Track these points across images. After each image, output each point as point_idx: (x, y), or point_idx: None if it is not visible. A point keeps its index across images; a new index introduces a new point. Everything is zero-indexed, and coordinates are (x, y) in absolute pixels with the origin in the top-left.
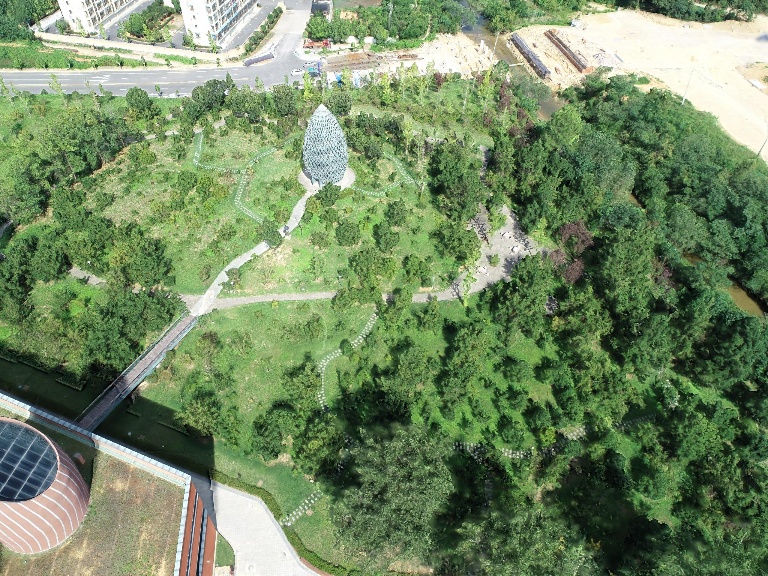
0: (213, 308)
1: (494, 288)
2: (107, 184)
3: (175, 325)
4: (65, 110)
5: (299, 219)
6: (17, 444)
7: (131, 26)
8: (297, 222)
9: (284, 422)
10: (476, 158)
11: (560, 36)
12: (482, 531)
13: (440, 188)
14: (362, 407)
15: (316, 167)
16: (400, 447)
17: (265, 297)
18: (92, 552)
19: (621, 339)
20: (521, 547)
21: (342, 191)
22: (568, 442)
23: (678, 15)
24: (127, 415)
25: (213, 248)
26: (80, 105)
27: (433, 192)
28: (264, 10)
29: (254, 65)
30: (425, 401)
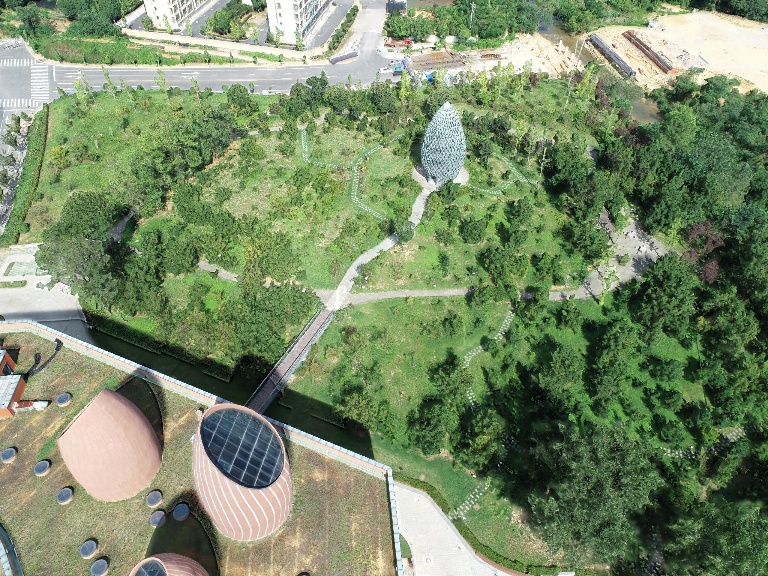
0: (348, 303)
1: (628, 287)
2: (221, 179)
3: (312, 319)
4: (168, 105)
5: (420, 216)
6: (249, 432)
7: (216, 23)
8: (419, 219)
9: (446, 417)
10: (584, 158)
11: (640, 37)
12: (701, 528)
13: (559, 187)
14: (512, 404)
15: (436, 164)
16: (607, 443)
17: (397, 293)
18: (307, 541)
19: (763, 340)
20: (754, 544)
21: (459, 189)
22: (736, 442)
23: (756, 17)
24: (279, 407)
25: (340, 244)
26: (182, 101)
27: (548, 191)
28: (339, 9)
29: (339, 63)
30: (575, 399)
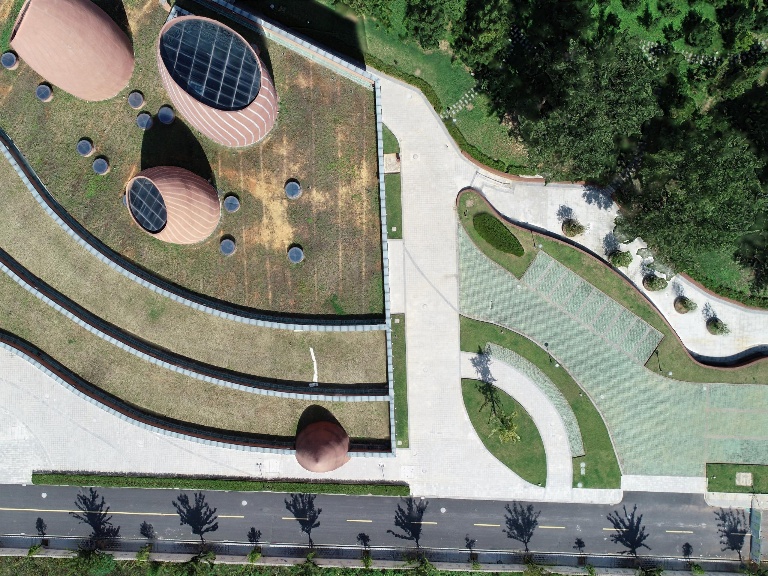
0: None
1: None
2: None
3: None
4: None
5: None
6: (217, 47)
7: None
8: None
9: (450, 6)
10: None
11: None
12: (681, 160)
13: None
14: None
15: None
16: (617, 67)
17: None
18: (294, 149)
19: None
20: (724, 182)
21: None
22: (767, 53)
23: None
24: None
25: None
26: None
27: None
28: None
29: None
30: None
